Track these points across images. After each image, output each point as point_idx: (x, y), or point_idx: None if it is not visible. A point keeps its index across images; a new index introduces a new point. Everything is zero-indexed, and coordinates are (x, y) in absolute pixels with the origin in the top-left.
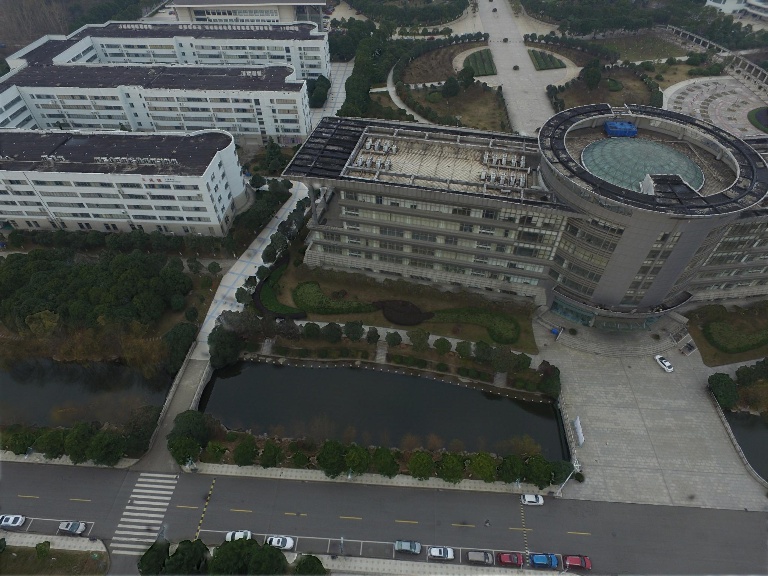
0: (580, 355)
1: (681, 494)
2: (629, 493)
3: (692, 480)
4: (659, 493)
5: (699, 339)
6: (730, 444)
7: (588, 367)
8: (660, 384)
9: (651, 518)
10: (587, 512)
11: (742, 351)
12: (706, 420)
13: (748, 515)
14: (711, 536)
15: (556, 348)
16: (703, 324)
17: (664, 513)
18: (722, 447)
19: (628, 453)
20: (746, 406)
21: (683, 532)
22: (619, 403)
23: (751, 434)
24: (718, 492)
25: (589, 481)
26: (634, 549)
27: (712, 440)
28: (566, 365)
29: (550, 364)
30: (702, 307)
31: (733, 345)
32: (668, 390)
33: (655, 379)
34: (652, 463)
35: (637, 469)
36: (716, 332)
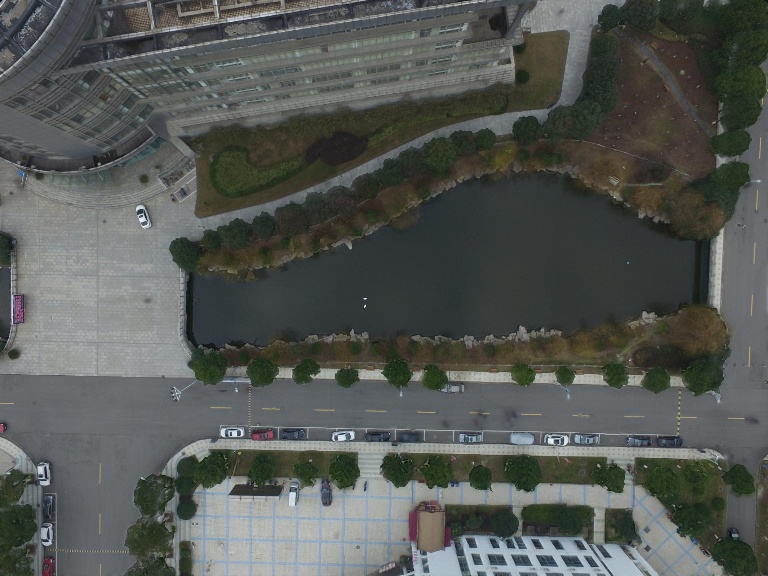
0: (50, 207)
1: (108, 365)
2: (59, 366)
3: (124, 352)
4: (87, 365)
5: (203, 177)
6: (178, 313)
7: (55, 224)
8: (132, 244)
9: (72, 388)
10: (15, 385)
11: (245, 195)
12: (165, 287)
13: (162, 382)
14: (121, 401)
15: (23, 197)
16: (216, 153)
17: (85, 383)
18: (168, 317)
19: (70, 327)
20: (224, 265)
21: (96, 399)
22: (78, 270)
23: (219, 295)
24: (144, 362)
25: (24, 357)
26: (48, 414)
27: (161, 310)
28: (30, 222)
29: (11, 221)
30: (209, 132)
31: (234, 188)
32: (138, 251)
33: (128, 237)
34: (91, 336)
35: (74, 343)
36: (222, 168)
